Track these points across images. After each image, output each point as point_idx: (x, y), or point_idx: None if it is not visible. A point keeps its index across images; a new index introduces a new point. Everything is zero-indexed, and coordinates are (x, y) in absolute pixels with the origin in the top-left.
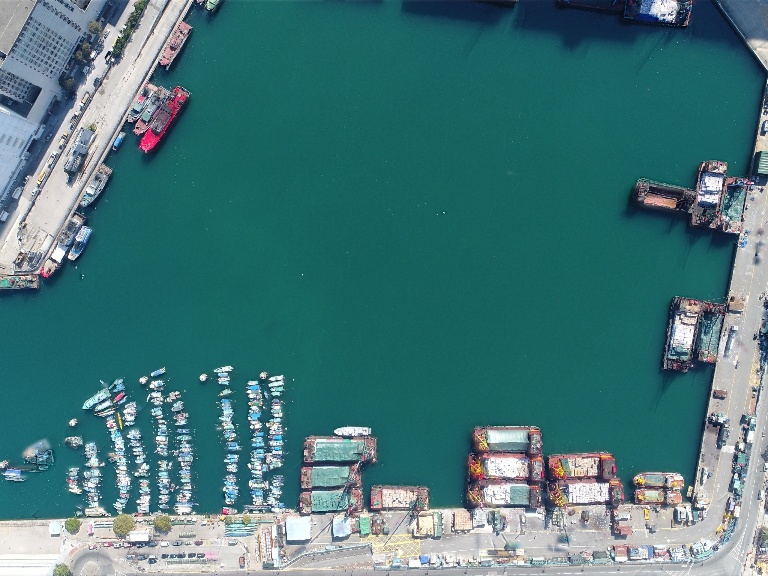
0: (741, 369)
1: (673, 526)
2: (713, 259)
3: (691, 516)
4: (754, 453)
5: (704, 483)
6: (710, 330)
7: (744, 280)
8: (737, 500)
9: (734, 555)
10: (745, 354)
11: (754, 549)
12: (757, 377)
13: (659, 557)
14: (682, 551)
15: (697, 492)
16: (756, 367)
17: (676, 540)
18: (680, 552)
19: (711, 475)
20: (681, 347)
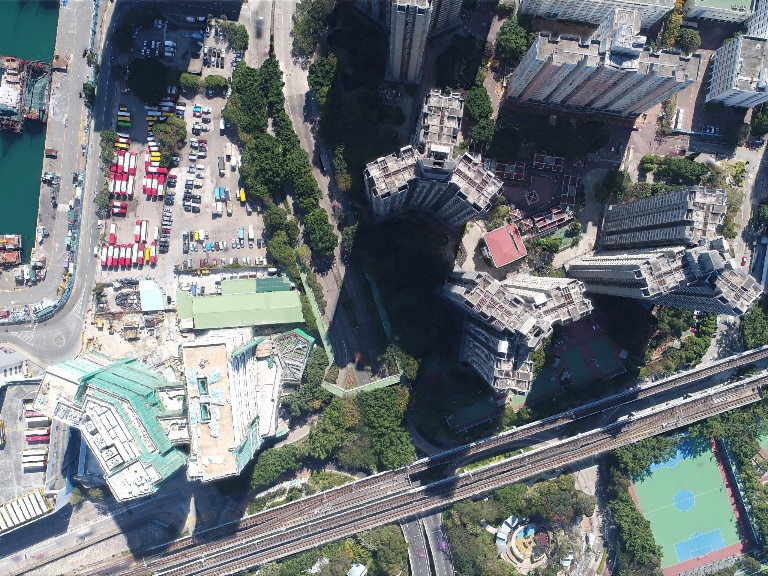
0: (70, 127)
1: (16, 287)
2: (41, 20)
3: (26, 274)
4: (88, 211)
5: (39, 242)
6: (31, 87)
7: (68, 38)
8: (71, 257)
9: (76, 313)
10: (73, 112)
11: (94, 306)
12: (85, 135)
13: (3, 318)
14: (23, 311)
15: (36, 252)
16: (84, 125)
17: (20, 301)
18: (21, 312)
19: (46, 233)
20: (5, 105)
